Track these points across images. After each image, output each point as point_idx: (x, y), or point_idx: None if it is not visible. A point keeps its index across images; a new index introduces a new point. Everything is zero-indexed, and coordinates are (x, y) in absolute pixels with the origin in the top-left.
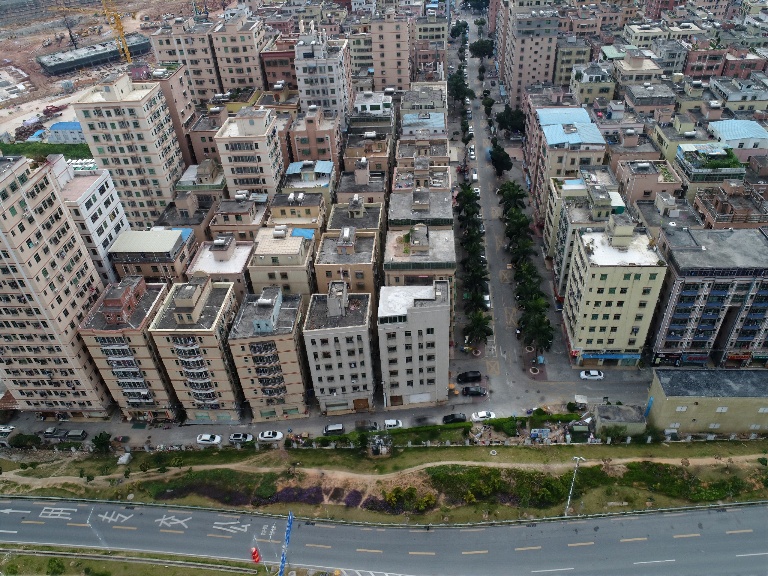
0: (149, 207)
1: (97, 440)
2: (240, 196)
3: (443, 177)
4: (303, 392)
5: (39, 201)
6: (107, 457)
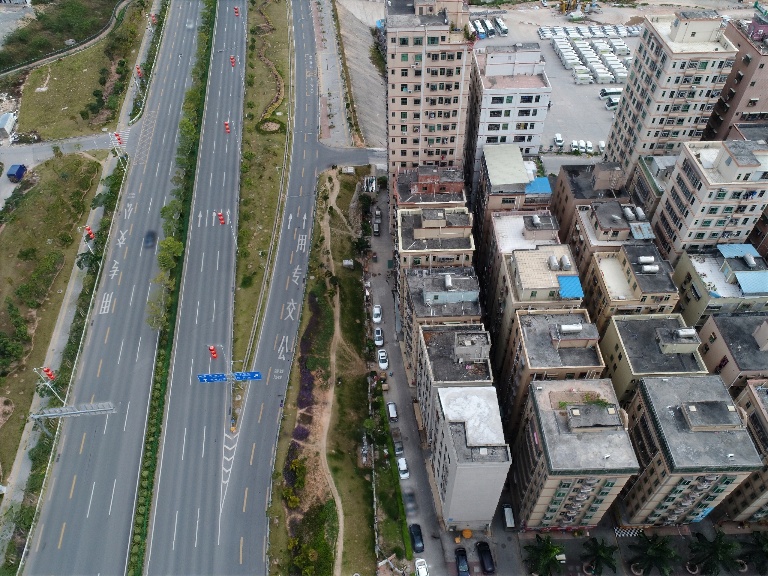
0: (619, 156)
1: (359, 240)
2: (628, 212)
3: None
4: (415, 368)
5: (438, 65)
6: (356, 254)
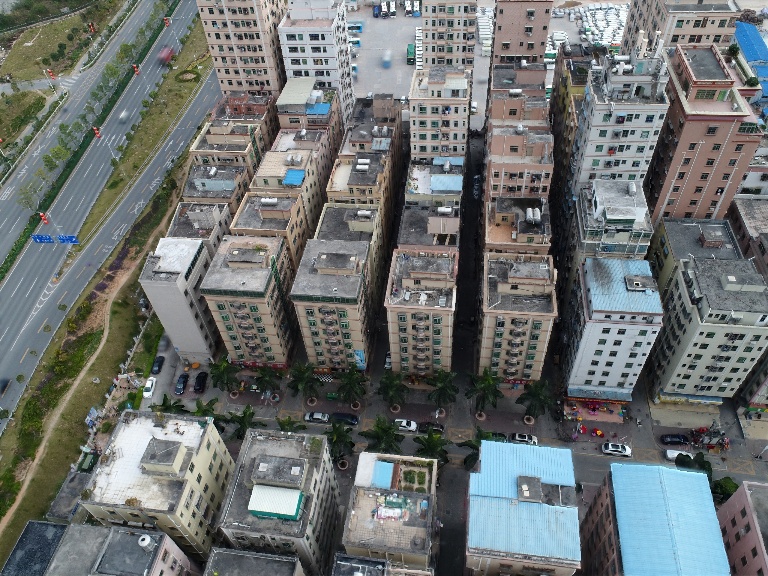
0: None
1: None
2: (374, 129)
3: (433, 305)
4: None
5: (236, 5)
6: None
